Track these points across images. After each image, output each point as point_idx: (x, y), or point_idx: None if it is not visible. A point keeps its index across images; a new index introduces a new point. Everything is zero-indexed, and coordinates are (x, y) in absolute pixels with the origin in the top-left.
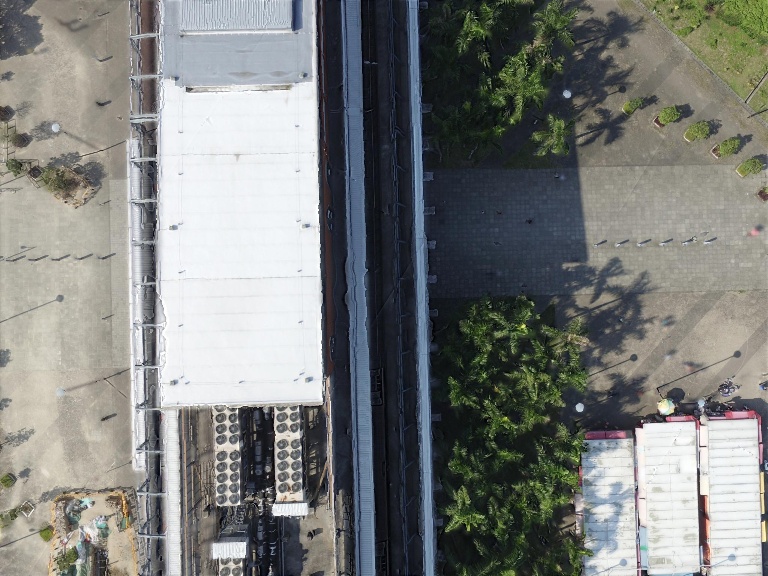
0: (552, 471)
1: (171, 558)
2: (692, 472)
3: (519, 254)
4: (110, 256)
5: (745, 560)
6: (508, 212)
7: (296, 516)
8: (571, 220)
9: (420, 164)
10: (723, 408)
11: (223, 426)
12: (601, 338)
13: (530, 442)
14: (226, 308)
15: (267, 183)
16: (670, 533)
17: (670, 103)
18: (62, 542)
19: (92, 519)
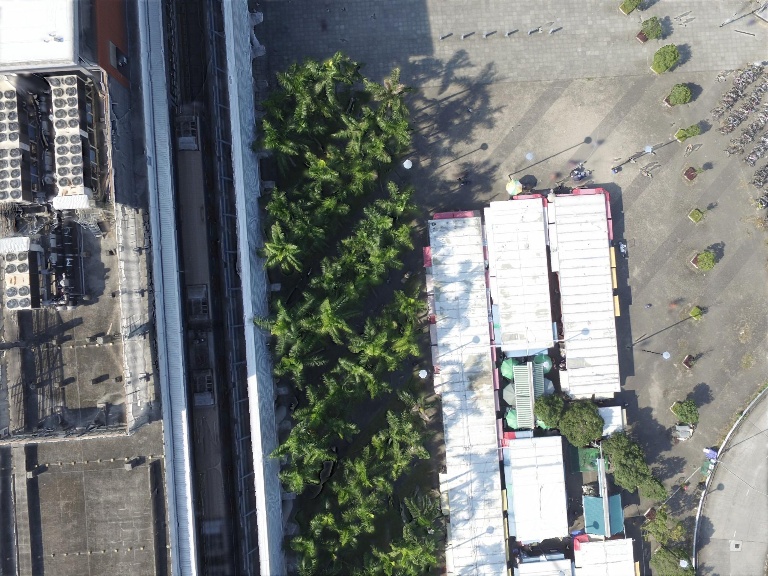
0: (379, 222)
1: None
2: (541, 248)
3: (366, 50)
4: None
5: (599, 334)
6: (353, 9)
7: (94, 232)
8: (416, 15)
9: None
10: None
11: (3, 124)
12: (451, 129)
13: (364, 206)
14: None
15: None
16: (522, 309)
17: None
18: None
19: None
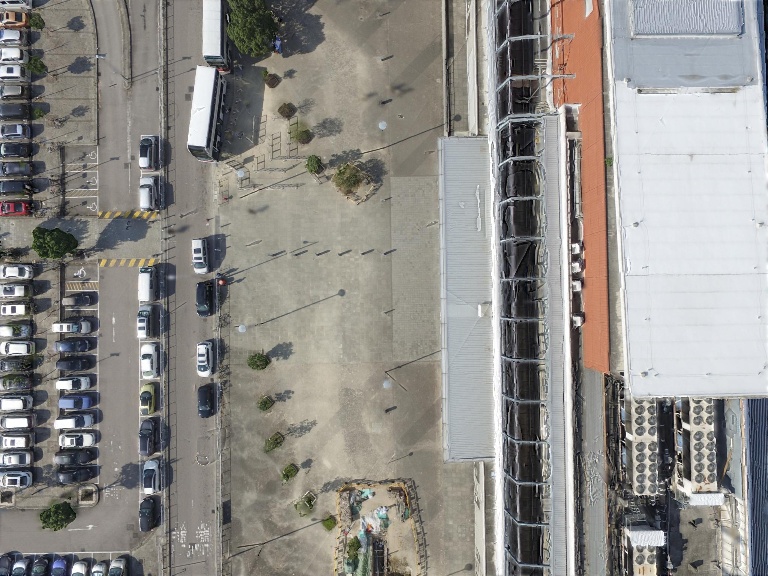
0: None
1: (556, 546)
2: None
3: None
4: (391, 252)
5: None
6: None
7: None
8: None
9: None
10: None
11: (642, 418)
12: None
13: None
14: (689, 303)
15: (721, 183)
16: None
17: None
18: (344, 532)
19: (373, 509)
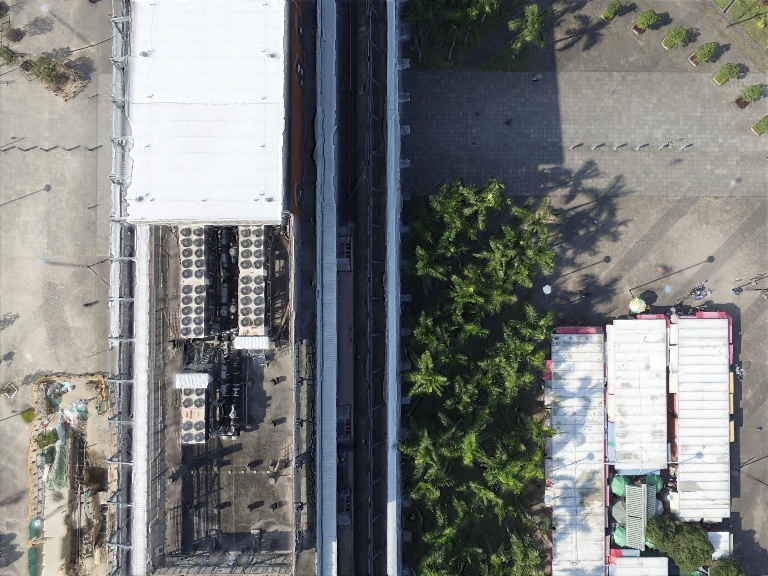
0: (518, 348)
1: (139, 400)
2: (661, 369)
3: (496, 155)
4: (97, 148)
5: (713, 458)
6: (486, 113)
7: (260, 361)
8: (548, 123)
9: (393, 38)
10: (695, 311)
11: (189, 261)
12: (575, 239)
13: (498, 325)
14: (191, 131)
15: (234, 15)
16: (638, 429)
17: None
18: (43, 423)
19: (72, 402)
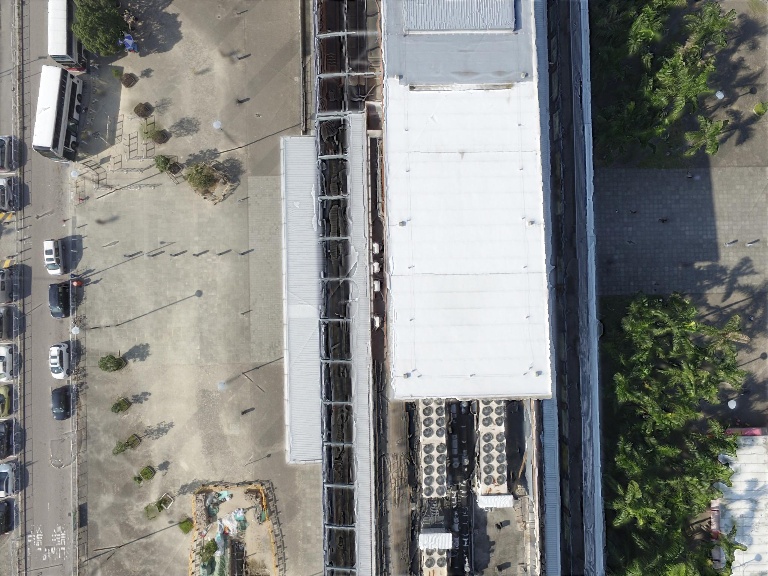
0: (708, 467)
1: (361, 549)
2: None
3: (652, 253)
4: (248, 252)
5: None
6: (641, 211)
7: (486, 508)
8: (703, 220)
9: (591, 163)
10: None
11: (430, 419)
12: None
13: (680, 438)
14: (455, 303)
15: (492, 181)
16: None
17: None
18: (201, 534)
19: (230, 512)
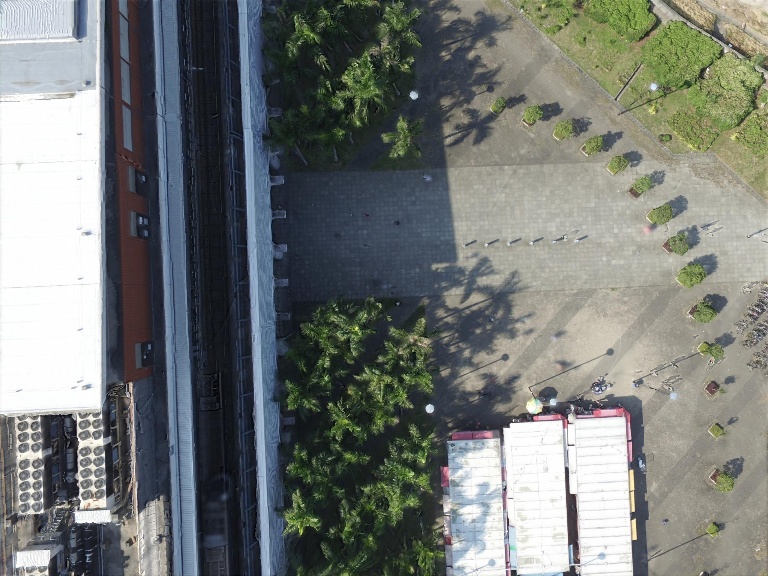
0: (399, 473)
1: None
2: (560, 471)
3: (388, 256)
4: None
5: (615, 558)
6: (376, 214)
7: (114, 523)
8: (440, 221)
9: (252, 168)
10: (595, 406)
11: (25, 434)
12: (472, 338)
13: (384, 444)
14: (5, 317)
15: (48, 192)
16: (538, 533)
17: (539, 102)
18: None
19: None
